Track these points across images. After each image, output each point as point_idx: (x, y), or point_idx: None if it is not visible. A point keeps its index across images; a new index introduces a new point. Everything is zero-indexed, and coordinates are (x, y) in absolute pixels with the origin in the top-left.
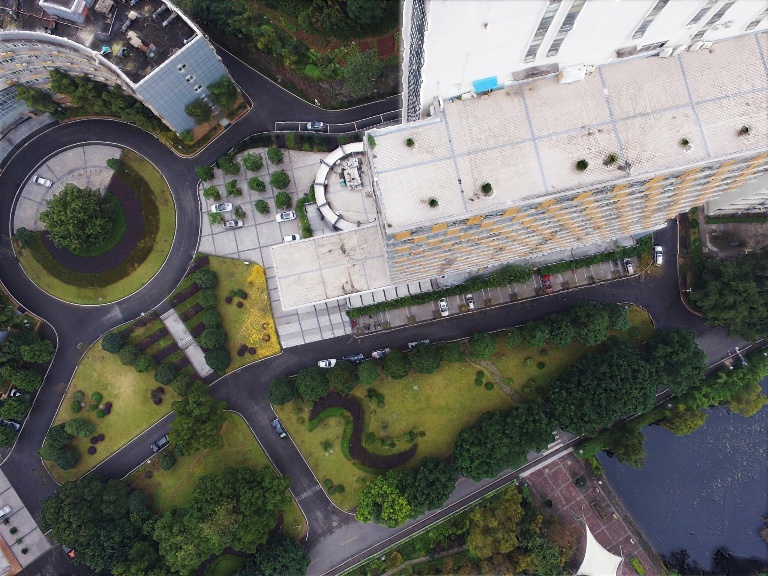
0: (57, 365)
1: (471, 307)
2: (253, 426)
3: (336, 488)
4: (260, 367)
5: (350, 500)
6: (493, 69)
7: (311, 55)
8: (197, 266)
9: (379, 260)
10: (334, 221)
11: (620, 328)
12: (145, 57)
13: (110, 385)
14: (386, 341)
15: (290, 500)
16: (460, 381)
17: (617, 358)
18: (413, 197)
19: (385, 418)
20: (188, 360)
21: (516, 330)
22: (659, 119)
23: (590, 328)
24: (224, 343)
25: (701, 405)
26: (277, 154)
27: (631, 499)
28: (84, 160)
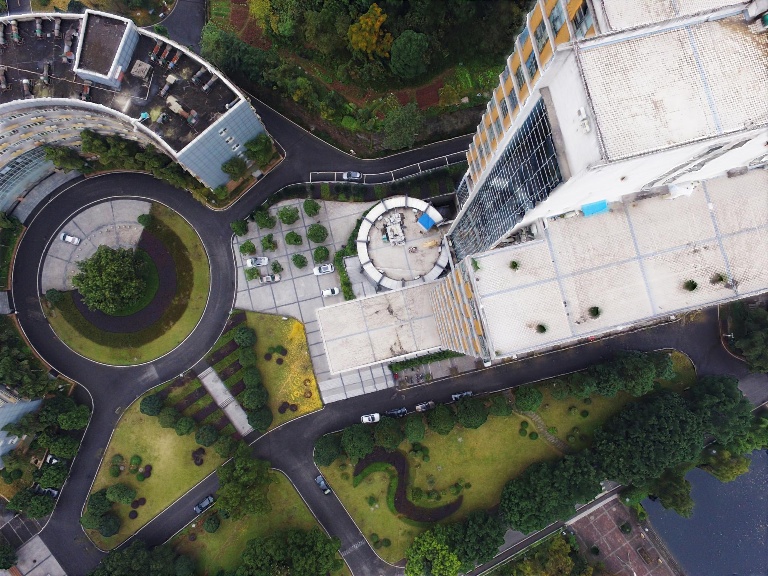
0: (93, 429)
1: (514, 357)
2: (296, 483)
3: (382, 542)
4: (302, 423)
5: (396, 553)
6: (606, 196)
7: (348, 107)
8: (234, 323)
9: (427, 320)
10: (378, 279)
11: (666, 378)
12: (185, 123)
13: (149, 447)
14: (429, 393)
15: (342, 563)
16: (504, 432)
17: (664, 409)
18: (517, 321)
19: (430, 471)
20: (228, 419)
21: (563, 383)
22: (765, 234)
23: (638, 381)
24: (265, 401)
25: (745, 451)
26: (315, 208)
27: (675, 542)
28: (112, 215)
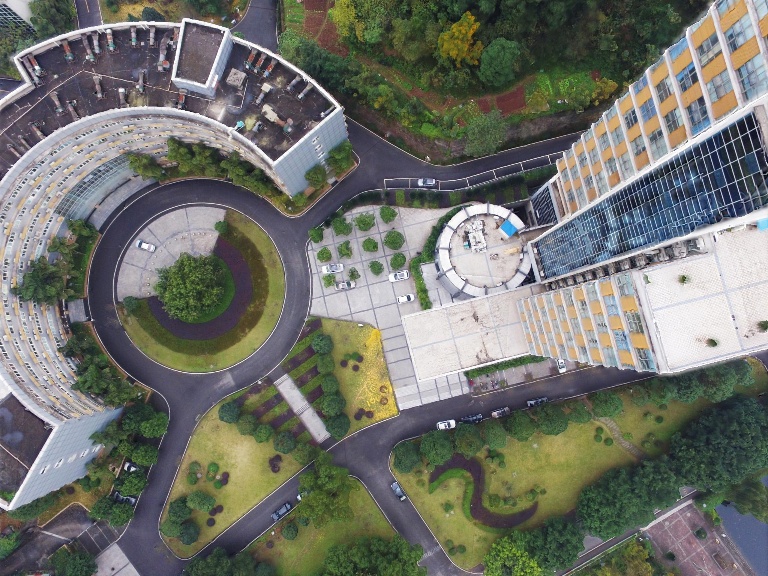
0: (170, 436)
1: None
2: (372, 490)
3: (457, 549)
4: (377, 430)
5: (471, 559)
6: None
7: (429, 114)
8: (310, 330)
9: (513, 327)
10: (461, 286)
11: (745, 384)
12: (281, 131)
13: (226, 455)
14: (504, 400)
15: (426, 570)
16: (579, 438)
17: (745, 415)
18: (686, 335)
19: (505, 477)
20: (304, 426)
21: (642, 389)
22: None
23: (720, 387)
24: None
25: None
26: (393, 215)
27: (749, 548)
28: (187, 222)
